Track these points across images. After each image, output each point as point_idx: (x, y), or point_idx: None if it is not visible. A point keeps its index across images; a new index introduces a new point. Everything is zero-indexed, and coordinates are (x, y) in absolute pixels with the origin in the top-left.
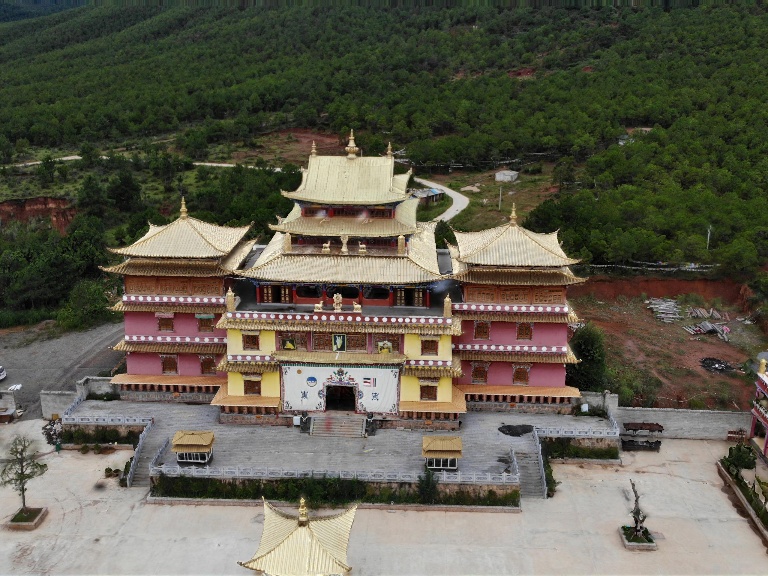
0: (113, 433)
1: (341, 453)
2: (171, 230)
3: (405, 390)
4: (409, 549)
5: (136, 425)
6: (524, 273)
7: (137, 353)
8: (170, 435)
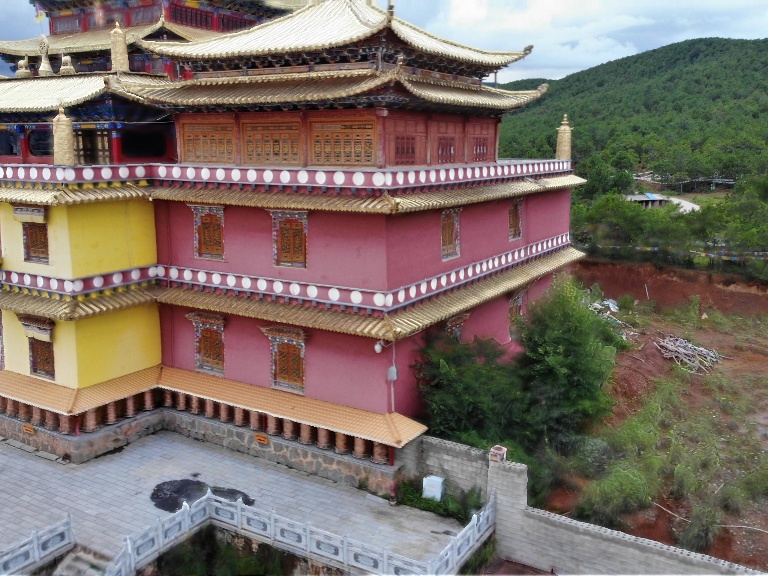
0: None
1: None
2: None
3: (9, 344)
4: None
5: None
6: (291, 81)
7: None
8: None
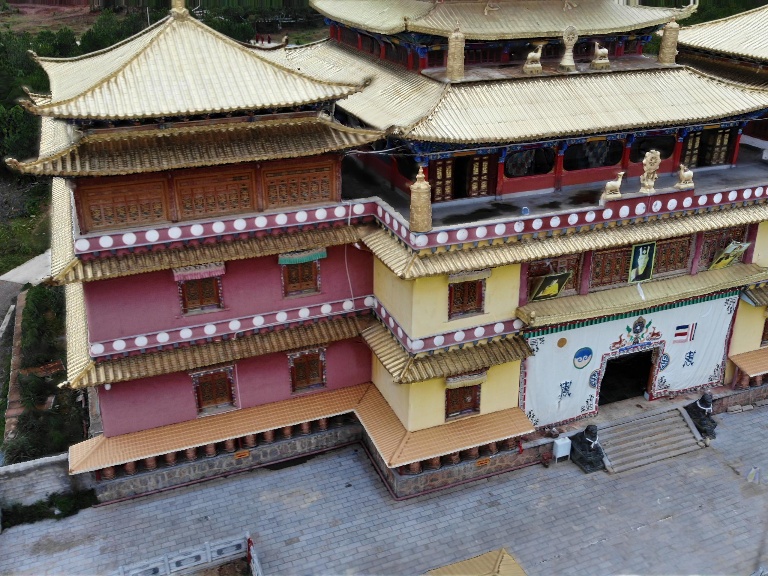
0: None
1: (719, 498)
2: (165, 48)
3: (740, 333)
4: None
5: (202, 568)
6: None
7: (129, 381)
8: (321, 573)
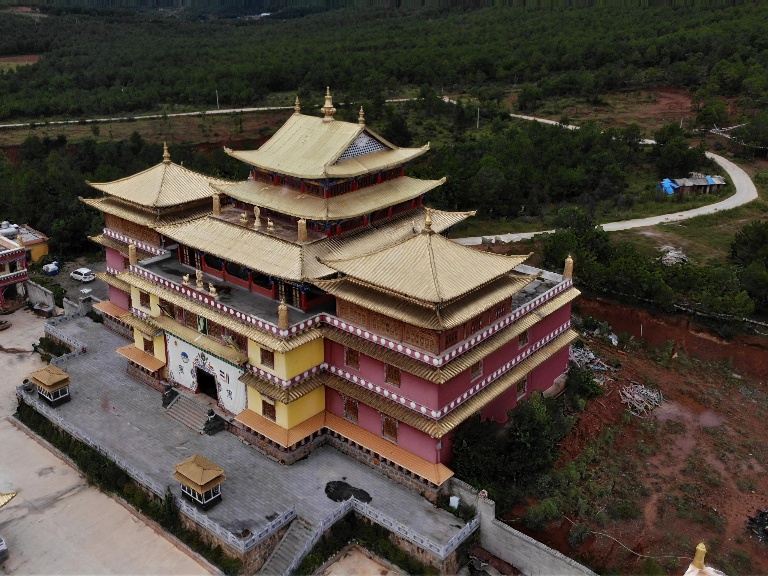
0: (64, 351)
1: (158, 440)
2: (148, 173)
3: (251, 398)
4: (87, 565)
5: None
6: (396, 299)
7: None
8: (81, 367)
